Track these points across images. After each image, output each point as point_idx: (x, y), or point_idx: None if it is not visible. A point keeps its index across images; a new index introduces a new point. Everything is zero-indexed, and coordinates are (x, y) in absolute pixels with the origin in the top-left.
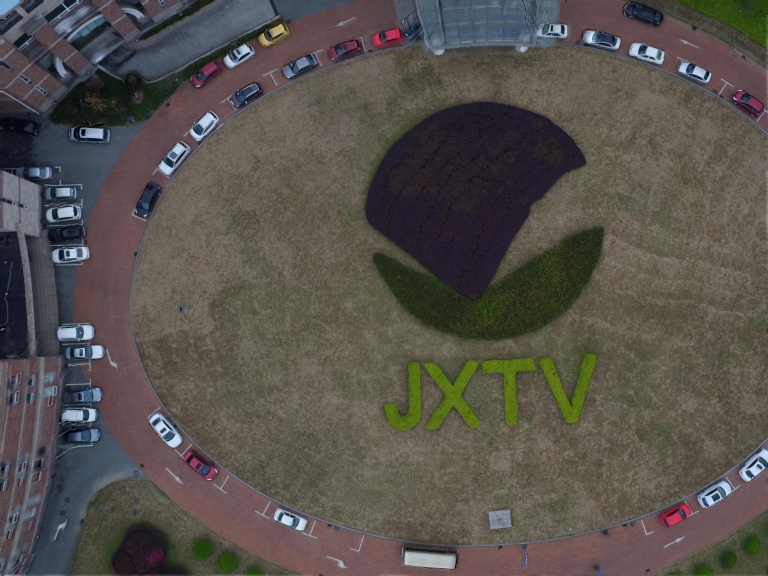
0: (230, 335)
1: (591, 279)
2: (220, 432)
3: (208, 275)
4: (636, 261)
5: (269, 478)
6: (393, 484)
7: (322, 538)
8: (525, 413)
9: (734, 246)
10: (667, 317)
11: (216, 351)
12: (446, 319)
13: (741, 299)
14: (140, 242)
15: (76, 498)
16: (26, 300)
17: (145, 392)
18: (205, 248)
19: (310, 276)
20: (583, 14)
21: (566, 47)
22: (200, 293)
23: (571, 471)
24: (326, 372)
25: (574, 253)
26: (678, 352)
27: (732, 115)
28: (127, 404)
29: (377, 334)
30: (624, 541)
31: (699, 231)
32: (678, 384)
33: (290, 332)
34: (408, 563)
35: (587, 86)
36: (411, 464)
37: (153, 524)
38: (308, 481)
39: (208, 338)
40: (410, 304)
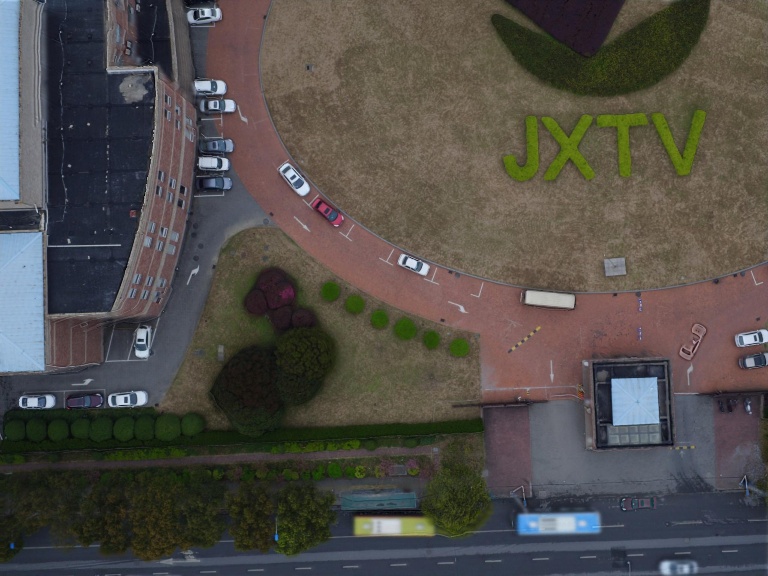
0: (355, 92)
1: (699, 41)
2: (346, 183)
3: (334, 36)
4: (742, 25)
5: (392, 226)
6: (511, 233)
7: (443, 284)
8: (638, 166)
9: None
10: None
11: (342, 107)
12: (562, 75)
13: None
14: (269, 6)
15: (208, 244)
16: (171, 41)
17: (274, 145)
18: (331, 11)
19: (431, 37)
20: None
21: None
22: (326, 53)
23: (683, 222)
24: (447, 126)
25: (683, 15)
26: None
27: None
28: (257, 157)
29: (495, 90)
30: (735, 290)
31: None
32: None
33: (412, 89)
34: (529, 301)
35: None
36: (529, 214)
37: (282, 268)
38: (430, 229)
39: (334, 94)
40: (527, 61)
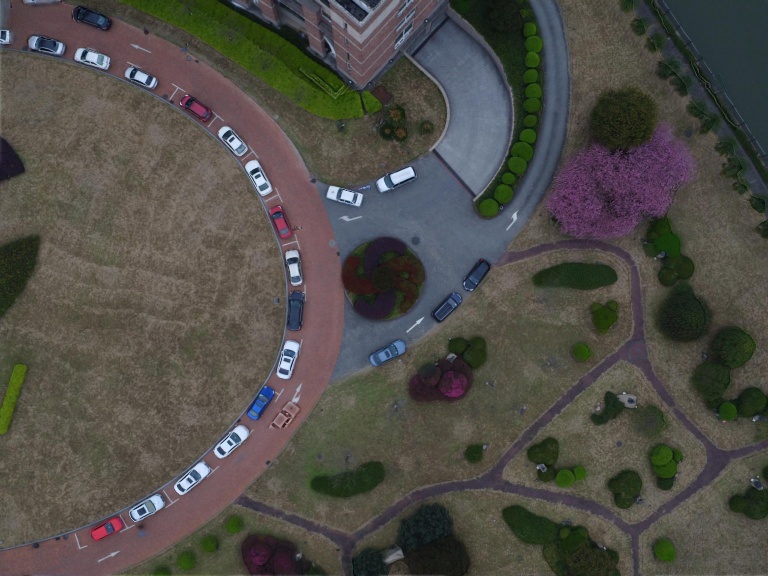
0: None
1: (26, 288)
2: None
3: None
4: (74, 270)
5: None
6: None
7: None
8: None
9: (178, 254)
10: (104, 327)
11: None
12: None
13: (183, 308)
14: None
15: None
16: None
17: None
18: None
19: None
20: (29, 19)
21: (13, 53)
22: None
23: (1, 483)
24: None
25: (6, 262)
26: (116, 362)
27: (182, 120)
28: None
29: None
30: (56, 555)
31: (141, 239)
32: (115, 395)
33: None
34: None
35: (32, 92)
36: None
37: None
38: None
39: None
40: None
